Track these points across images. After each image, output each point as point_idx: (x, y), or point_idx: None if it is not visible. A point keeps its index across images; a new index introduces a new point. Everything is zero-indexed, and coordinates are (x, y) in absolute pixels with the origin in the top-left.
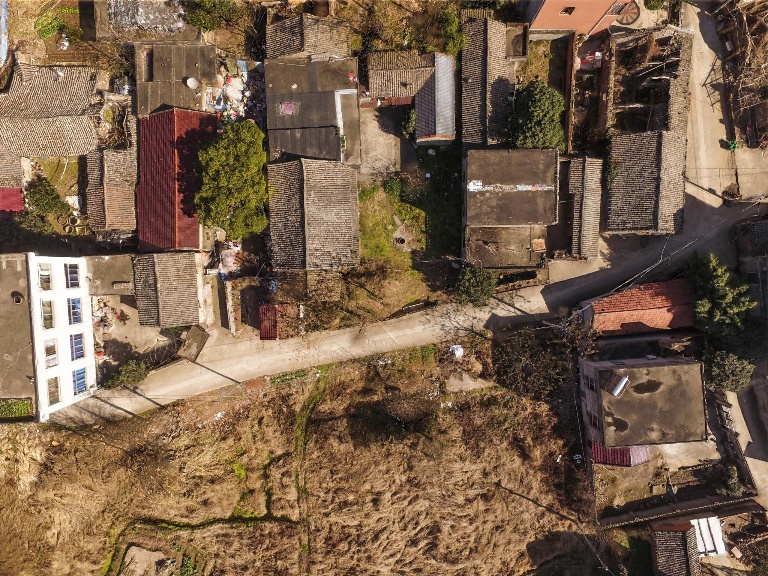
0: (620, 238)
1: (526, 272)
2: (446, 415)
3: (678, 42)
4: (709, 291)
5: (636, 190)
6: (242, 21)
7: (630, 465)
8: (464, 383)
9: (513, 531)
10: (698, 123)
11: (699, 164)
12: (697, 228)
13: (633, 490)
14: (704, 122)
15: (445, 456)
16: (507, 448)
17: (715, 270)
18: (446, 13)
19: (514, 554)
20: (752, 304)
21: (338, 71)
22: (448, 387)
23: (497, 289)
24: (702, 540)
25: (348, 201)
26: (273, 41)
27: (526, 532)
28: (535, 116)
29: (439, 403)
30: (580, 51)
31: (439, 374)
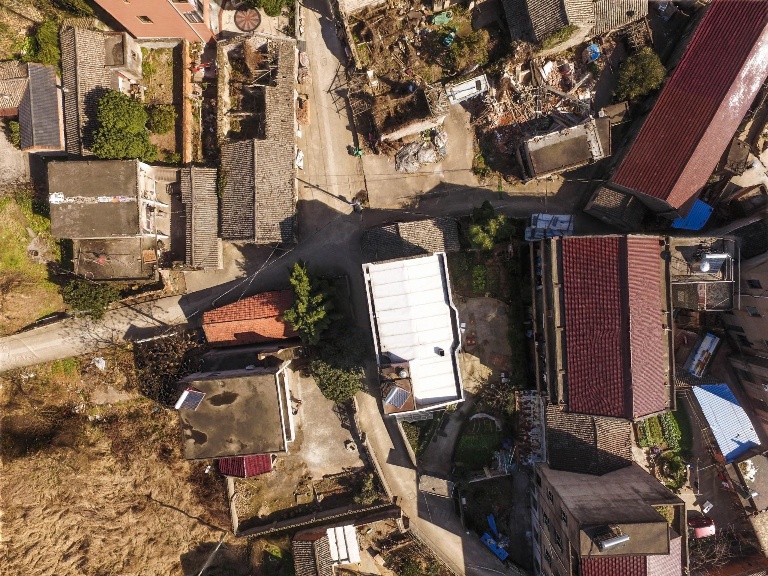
0: (254, 247)
1: (159, 283)
2: (94, 428)
3: (276, 49)
4: None
5: (240, 199)
6: None
7: (244, 476)
8: (109, 395)
9: (167, 543)
10: (325, 130)
11: (328, 171)
12: (329, 235)
13: (278, 499)
14: (331, 129)
15: (93, 469)
16: (156, 460)
17: (296, 279)
18: (39, 23)
19: (168, 566)
20: (318, 314)
21: None
22: (93, 400)
23: (135, 300)
24: (336, 549)
25: None
26: None
27: (179, 544)
28: (104, 127)
29: (87, 416)
30: (203, 59)
31: (84, 387)
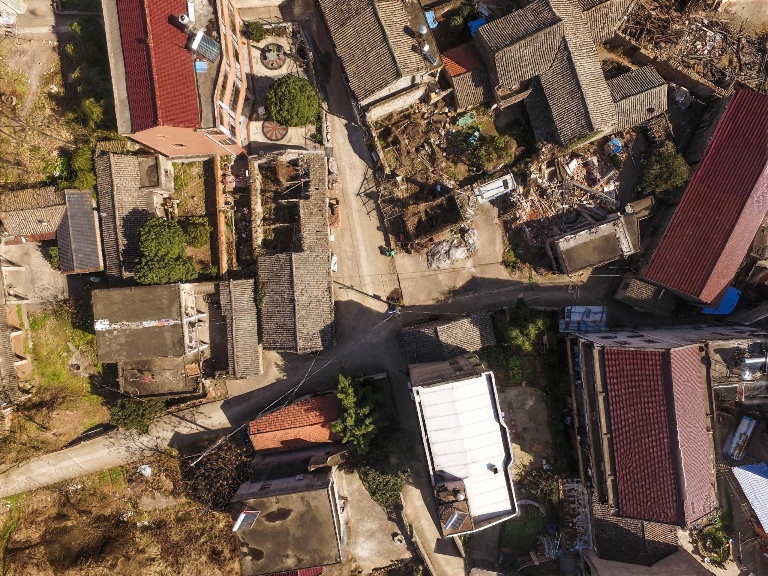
0: None
1: None
2: (143, 534)
3: (307, 163)
4: (343, 411)
5: (280, 310)
6: None
7: None
8: (157, 501)
9: None
10: (356, 232)
11: (362, 271)
12: None
13: None
14: (362, 230)
15: (145, 575)
16: (206, 562)
17: (342, 392)
18: (74, 150)
19: None
20: (367, 428)
21: None
22: (141, 507)
23: None
24: None
25: None
26: None
27: None
28: (147, 255)
29: (135, 523)
30: (233, 169)
31: (131, 495)
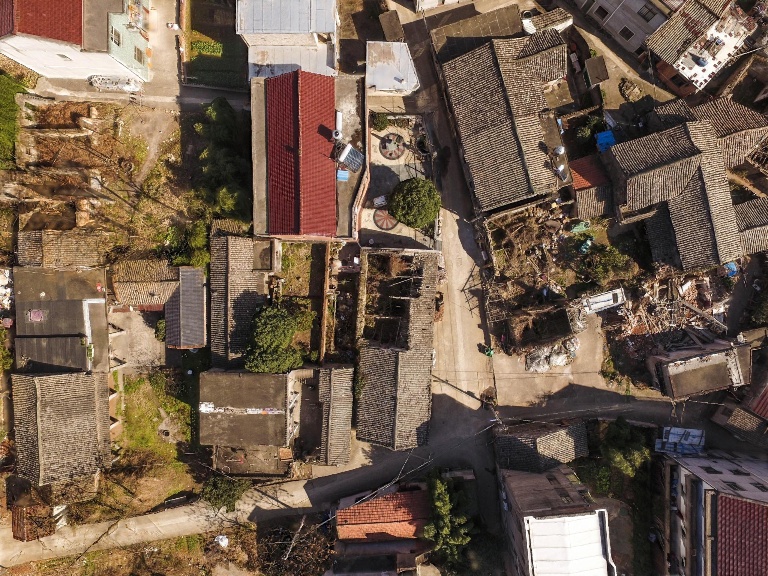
0: None
1: None
2: None
3: (421, 261)
4: (437, 516)
5: (379, 405)
6: (2, 220)
7: None
8: (230, 572)
9: None
10: (457, 327)
11: (458, 367)
12: (456, 429)
13: None
14: (463, 326)
15: None
16: None
17: (439, 499)
18: (192, 228)
19: None
20: (464, 541)
21: (86, 281)
22: (214, 575)
23: None
24: None
25: (93, 410)
26: (23, 248)
27: None
28: (260, 346)
29: None
30: (341, 254)
31: (205, 562)
